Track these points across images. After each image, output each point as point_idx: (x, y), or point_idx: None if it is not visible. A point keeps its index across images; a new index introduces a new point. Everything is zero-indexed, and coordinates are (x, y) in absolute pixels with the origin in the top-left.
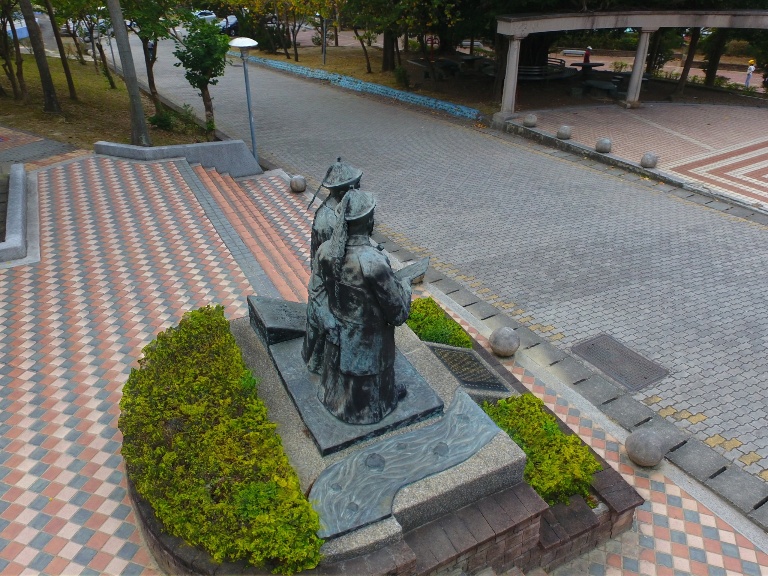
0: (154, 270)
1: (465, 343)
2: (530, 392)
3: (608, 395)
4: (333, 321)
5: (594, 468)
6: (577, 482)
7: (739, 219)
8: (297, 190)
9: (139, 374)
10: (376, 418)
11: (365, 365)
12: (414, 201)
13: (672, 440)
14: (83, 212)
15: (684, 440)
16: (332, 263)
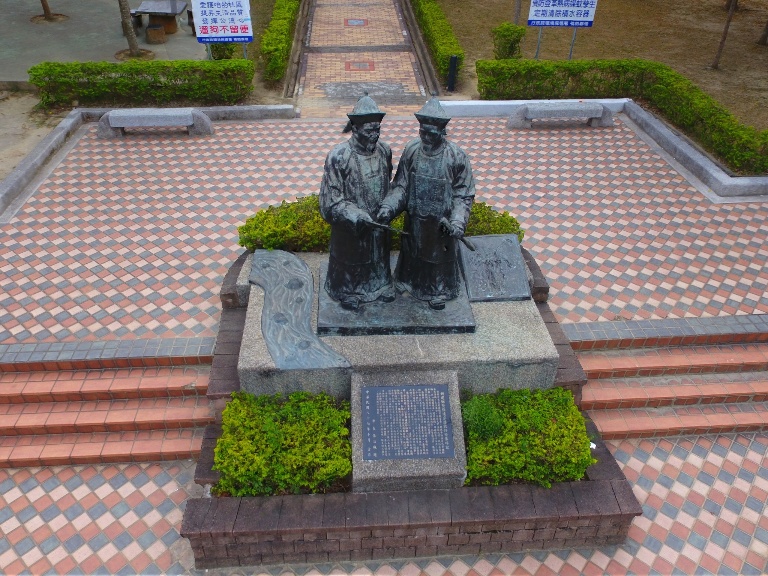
0: (699, 259)
1: None
2: (384, 522)
3: None
4: None
5: None
6: None
7: None
8: None
9: None
10: None
11: None
12: None
13: None
14: None
15: None
16: None
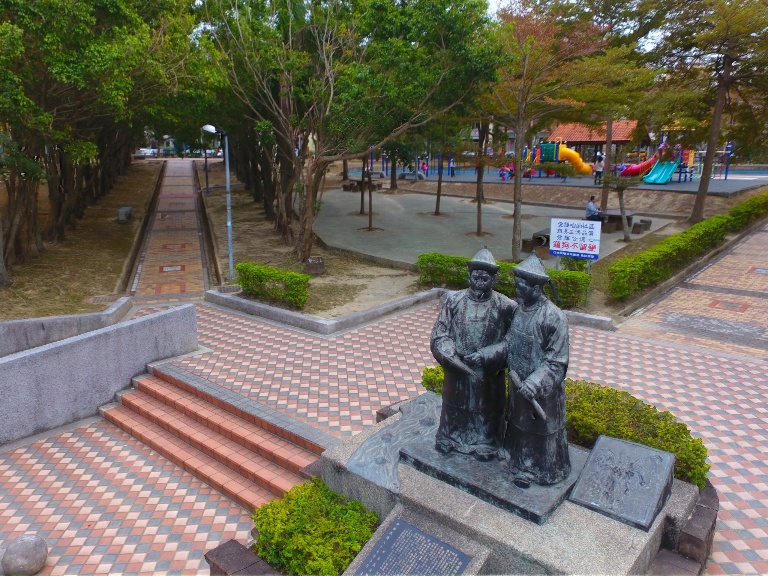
0: None
1: None
2: None
3: None
4: None
5: None
6: None
7: None
8: None
9: (633, 398)
10: None
11: None
12: None
13: None
14: None
15: None
16: None
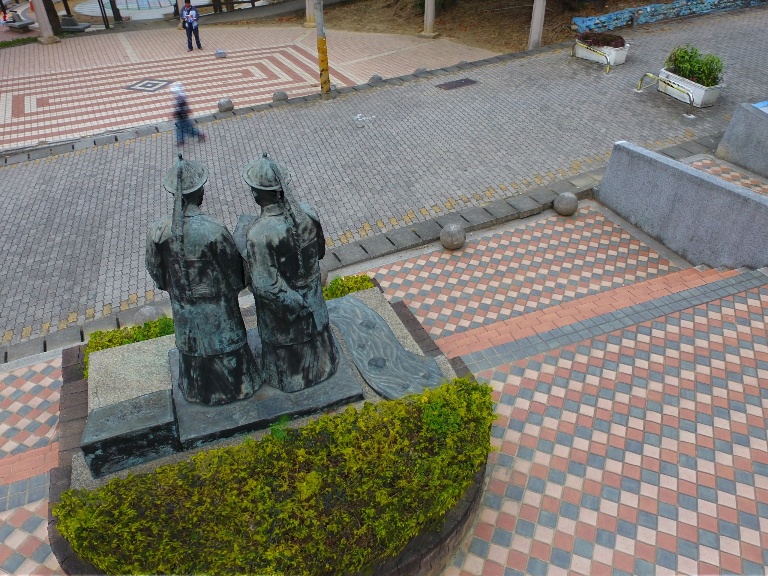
0: None
1: None
2: None
3: None
4: (299, 295)
5: None
6: None
7: (52, 158)
8: None
9: (215, 567)
10: None
11: None
12: None
13: None
14: None
15: None
16: (289, 237)
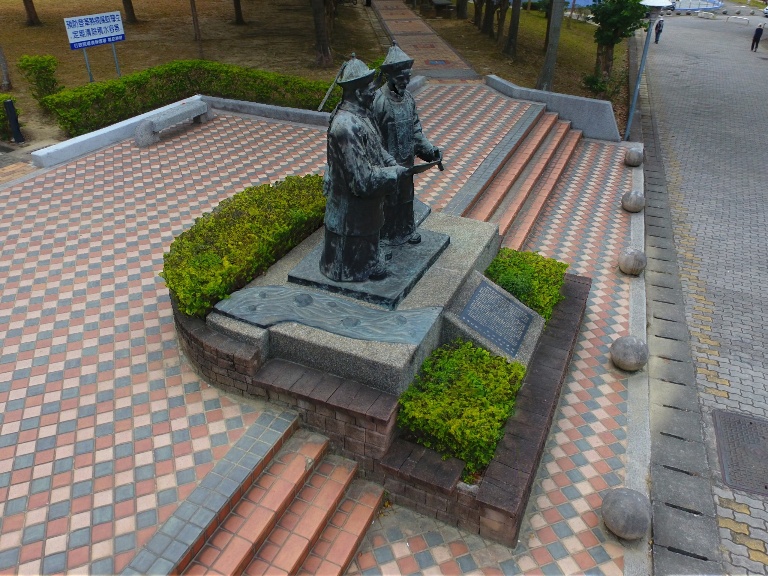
0: None
1: (539, 307)
2: (557, 383)
3: (684, 465)
4: None
5: (476, 438)
6: (455, 440)
7: None
8: (628, 163)
9: (264, 186)
10: (336, 276)
11: (334, 222)
12: (761, 219)
13: (688, 544)
14: (421, 117)
15: (706, 556)
16: None
